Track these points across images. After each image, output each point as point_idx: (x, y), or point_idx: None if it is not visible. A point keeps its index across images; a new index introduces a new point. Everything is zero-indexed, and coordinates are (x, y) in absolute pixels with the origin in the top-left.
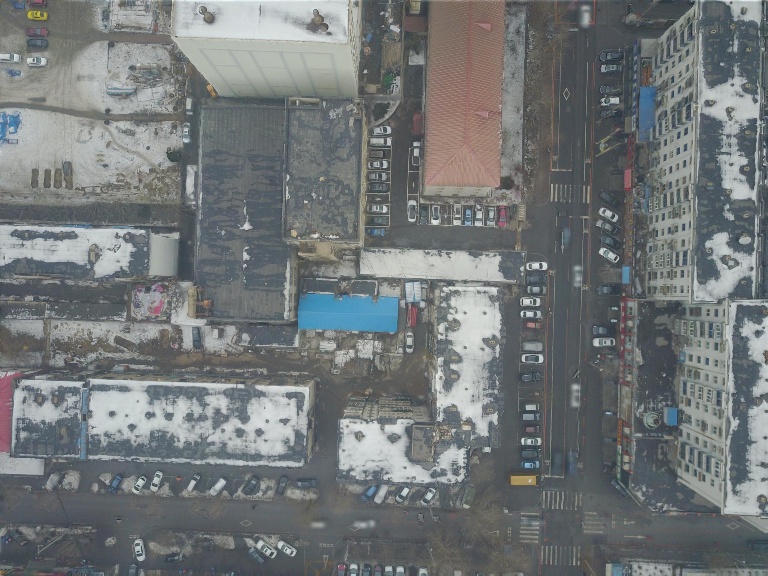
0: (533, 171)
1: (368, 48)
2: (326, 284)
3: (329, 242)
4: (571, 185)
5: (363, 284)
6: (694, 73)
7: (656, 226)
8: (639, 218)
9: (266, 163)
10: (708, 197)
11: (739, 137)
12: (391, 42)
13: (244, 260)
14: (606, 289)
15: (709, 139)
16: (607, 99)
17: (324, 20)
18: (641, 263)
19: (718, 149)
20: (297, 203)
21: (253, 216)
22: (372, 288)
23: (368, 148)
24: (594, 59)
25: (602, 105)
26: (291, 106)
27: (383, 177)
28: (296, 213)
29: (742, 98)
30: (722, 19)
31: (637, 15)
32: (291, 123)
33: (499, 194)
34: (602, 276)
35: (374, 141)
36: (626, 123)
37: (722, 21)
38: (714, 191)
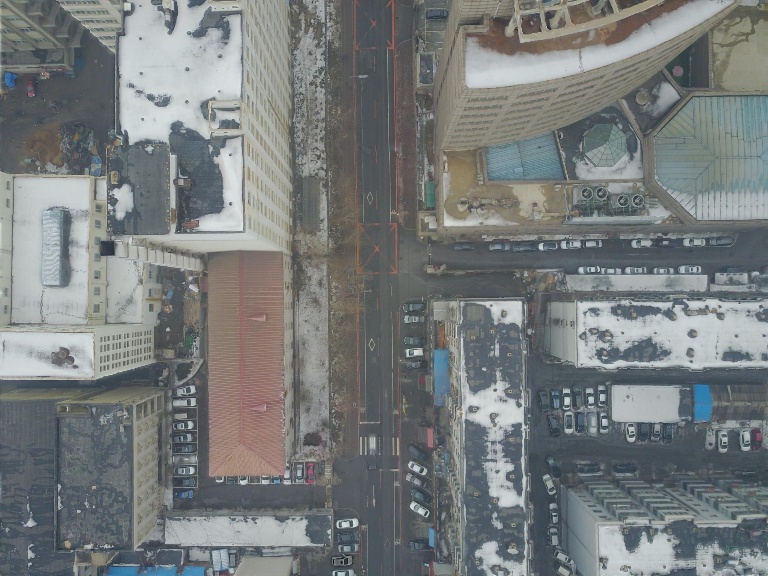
0: (341, 425)
1: (169, 306)
2: (131, 555)
3: (103, 553)
4: (380, 438)
5: (169, 554)
6: (458, 377)
7: (453, 496)
8: (442, 479)
9: (49, 456)
10: (476, 505)
11: (504, 443)
12: (192, 299)
13: (29, 558)
14: (417, 545)
15: (475, 446)
16: (411, 351)
17: (70, 353)
18: (446, 525)
19: (484, 456)
20: (70, 513)
21: (37, 512)
22: (178, 558)
23: (173, 408)
24: (398, 308)
25: (406, 357)
26: (59, 415)
27: (188, 438)
28: (69, 523)
29: (506, 403)
30: (483, 323)
31: (435, 268)
32: (61, 430)
33: (307, 450)
34: (414, 530)
35: (177, 403)
36: (426, 382)
37: (483, 325)
38: (481, 500)
